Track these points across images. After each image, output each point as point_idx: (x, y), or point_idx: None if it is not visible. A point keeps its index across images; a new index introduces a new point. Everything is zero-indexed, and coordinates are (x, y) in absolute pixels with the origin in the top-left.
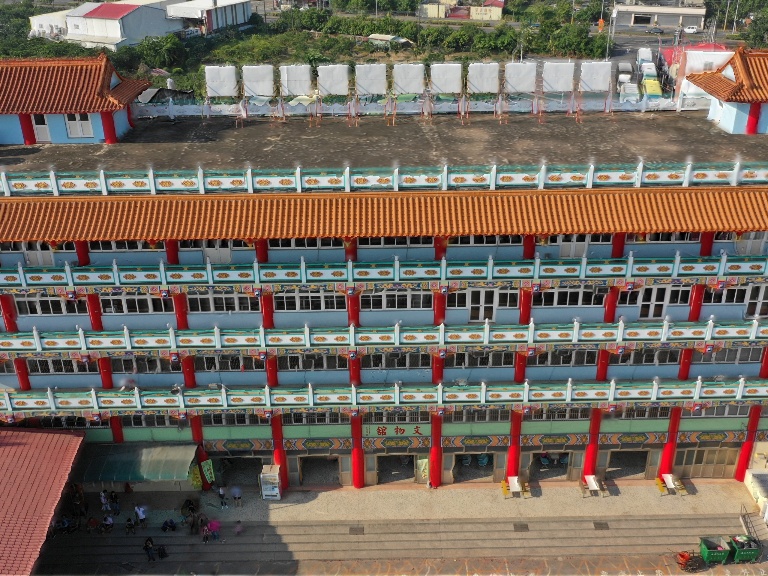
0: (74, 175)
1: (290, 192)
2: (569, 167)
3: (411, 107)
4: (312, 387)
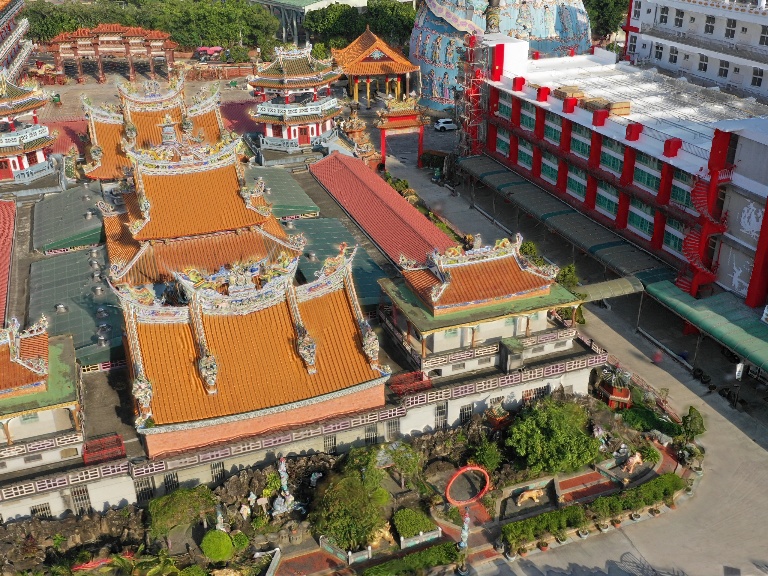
0: None
1: None
2: None
3: None
4: (6, 76)
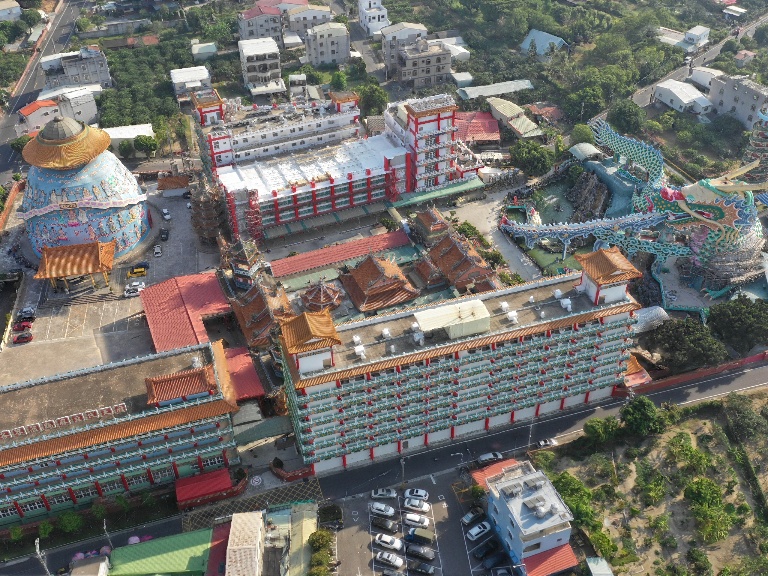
0: (145, 356)
1: (89, 371)
2: (6, 403)
3: (51, 435)
4: None
